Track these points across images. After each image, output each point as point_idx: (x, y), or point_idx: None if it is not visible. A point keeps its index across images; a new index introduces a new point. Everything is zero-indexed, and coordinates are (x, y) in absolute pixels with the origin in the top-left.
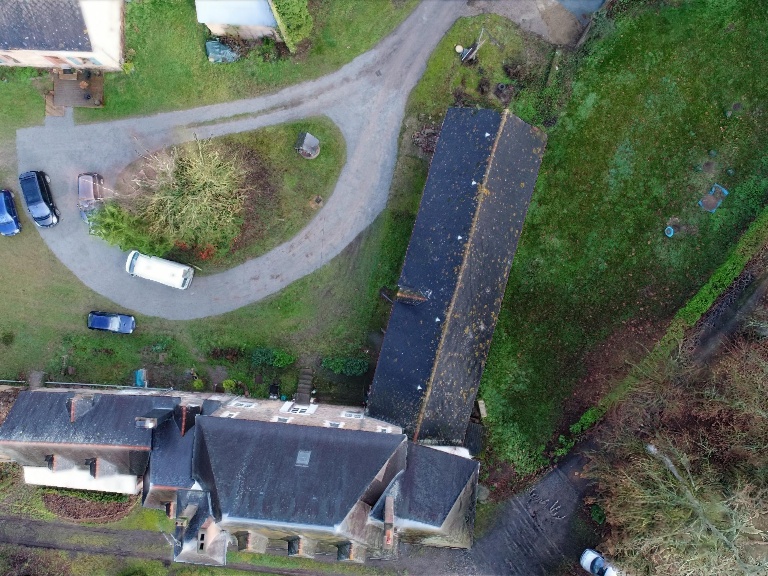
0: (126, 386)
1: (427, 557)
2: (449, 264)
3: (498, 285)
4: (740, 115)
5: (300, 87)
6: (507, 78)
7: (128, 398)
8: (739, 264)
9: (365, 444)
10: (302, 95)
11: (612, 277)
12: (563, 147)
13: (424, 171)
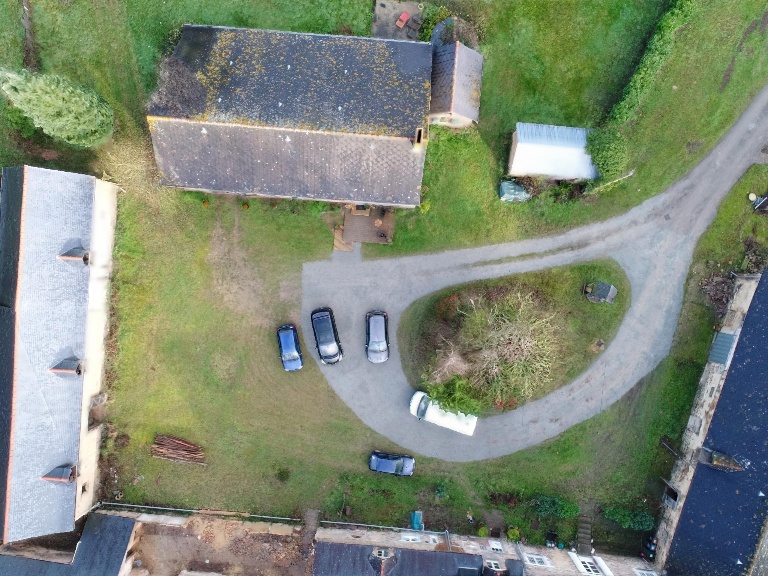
0: (402, 528)
1: None
2: None
3: None
4: None
5: (588, 228)
6: None
7: (429, 554)
8: None
9: None
10: (589, 236)
11: None
12: None
13: (711, 319)
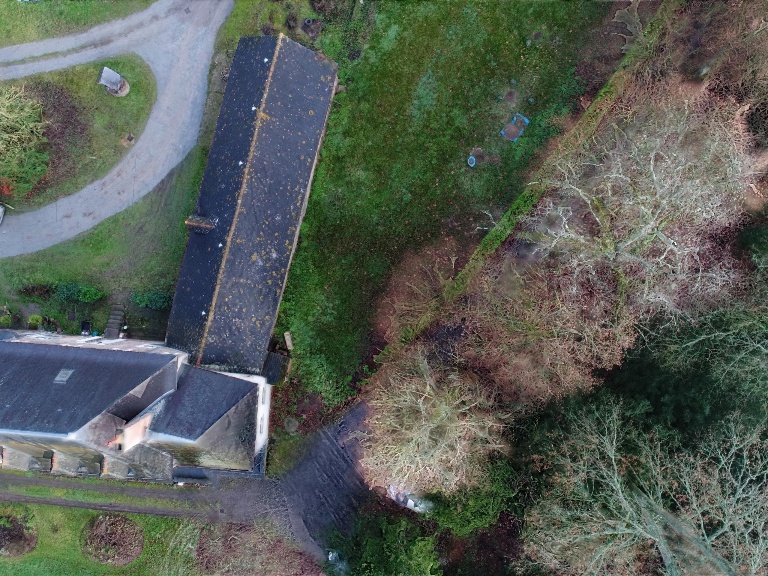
0: None
1: (238, 489)
2: (232, 190)
3: (291, 213)
4: (540, 44)
5: (109, 25)
6: (314, 13)
7: None
8: (537, 191)
9: (132, 363)
10: (112, 33)
11: (416, 208)
12: (366, 79)
13: None
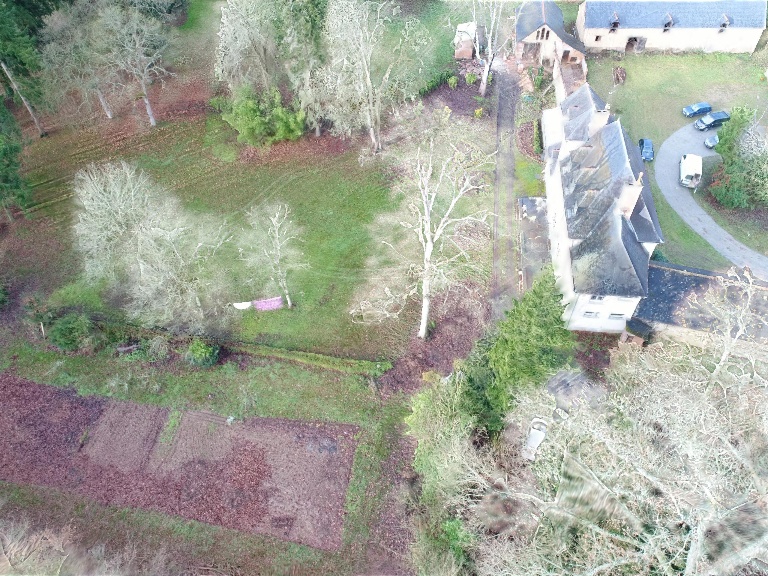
0: None
1: None
2: None
3: None
4: None
5: None
6: None
7: None
8: None
9: (653, 217)
10: None
11: None
12: None
13: None
